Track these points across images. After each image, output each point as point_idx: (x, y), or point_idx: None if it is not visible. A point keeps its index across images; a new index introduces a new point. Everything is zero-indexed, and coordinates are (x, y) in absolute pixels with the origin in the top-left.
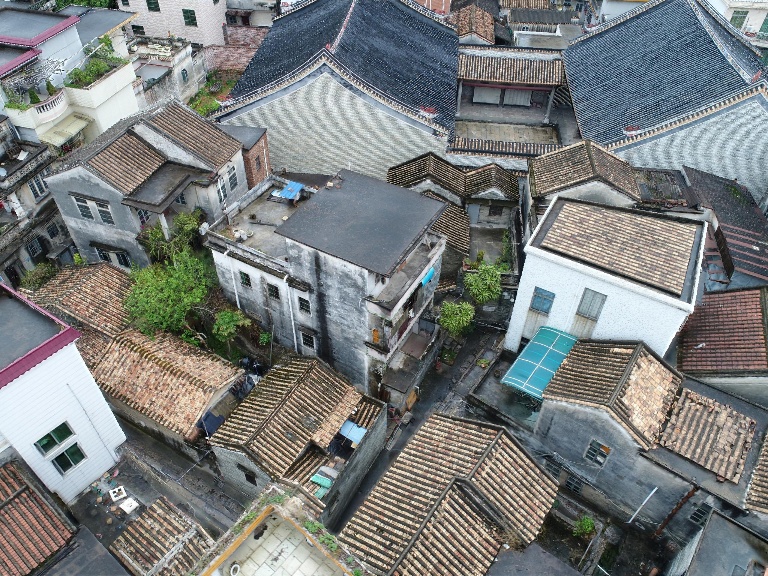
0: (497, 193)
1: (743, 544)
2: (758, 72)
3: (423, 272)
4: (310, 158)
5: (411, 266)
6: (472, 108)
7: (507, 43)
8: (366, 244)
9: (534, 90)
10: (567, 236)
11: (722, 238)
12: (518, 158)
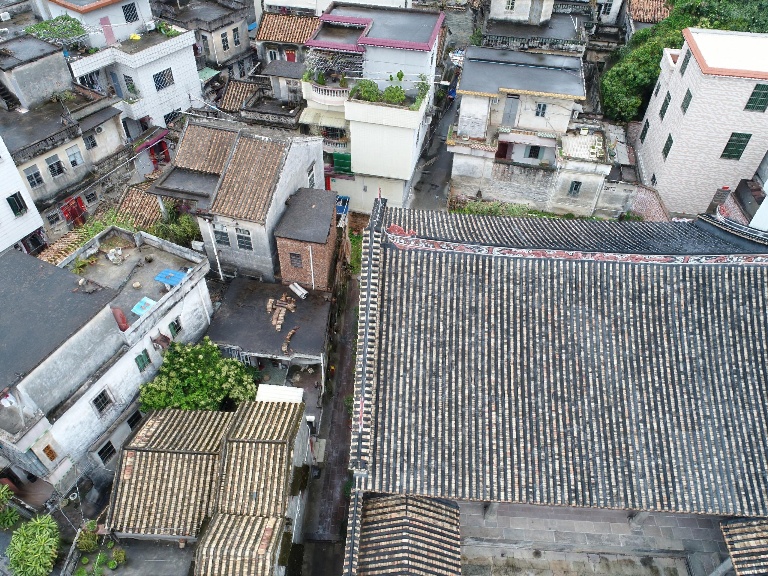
0: None
1: None
2: None
3: None
4: None
5: (1, 411)
6: None
7: None
8: None
9: None
10: None
11: None
12: None
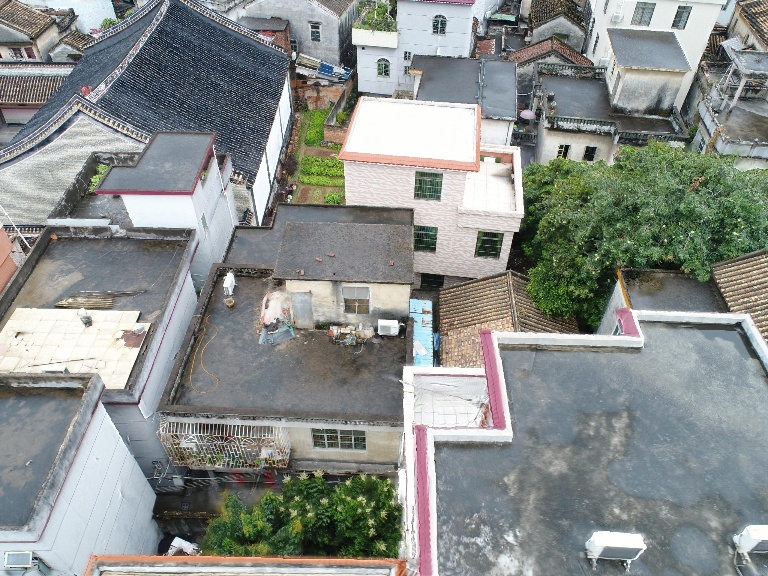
0: None
1: None
2: None
3: None
4: None
5: None
6: None
7: None
8: None
9: None
10: None
11: None
12: None
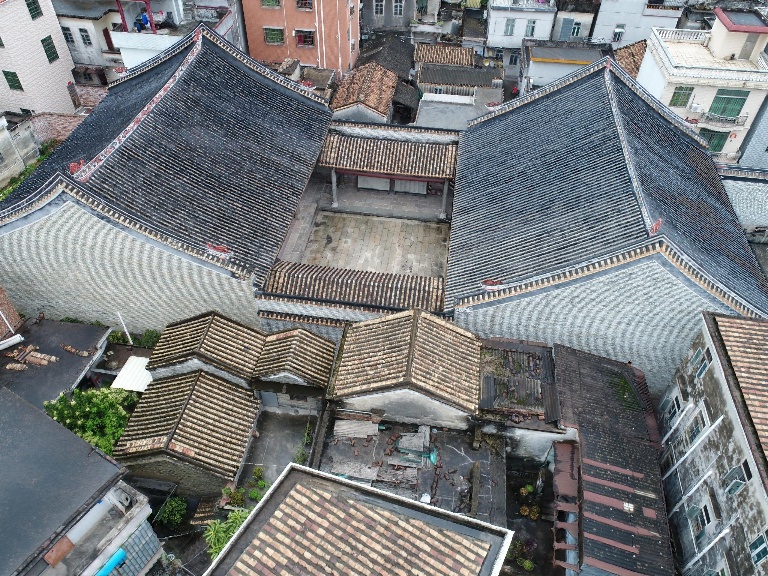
0: (293, 377)
1: None
2: (658, 221)
3: (87, 572)
4: (87, 294)
5: (83, 551)
6: (356, 195)
7: (411, 110)
8: None
9: (423, 181)
10: (267, 568)
11: None
12: (348, 309)
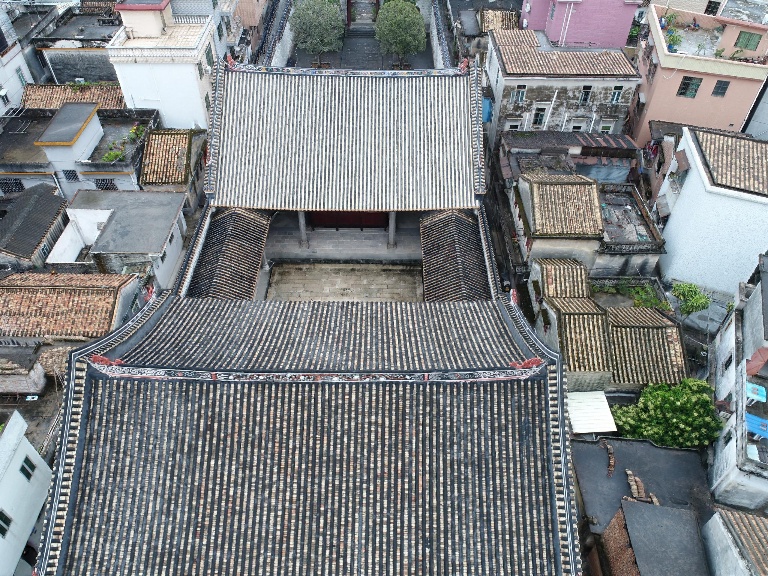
0: None
1: None
2: None
3: None
4: None
5: None
6: None
7: None
8: None
9: None
10: (764, 186)
11: (597, 149)
12: None
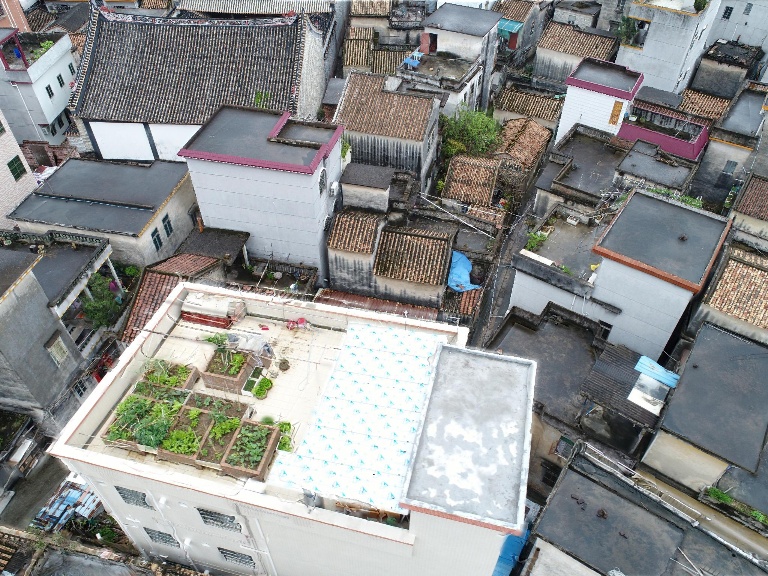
0: None
1: (563, 4)
2: None
3: None
4: None
5: None
6: None
7: None
8: (485, 17)
9: None
10: None
11: None
12: None
